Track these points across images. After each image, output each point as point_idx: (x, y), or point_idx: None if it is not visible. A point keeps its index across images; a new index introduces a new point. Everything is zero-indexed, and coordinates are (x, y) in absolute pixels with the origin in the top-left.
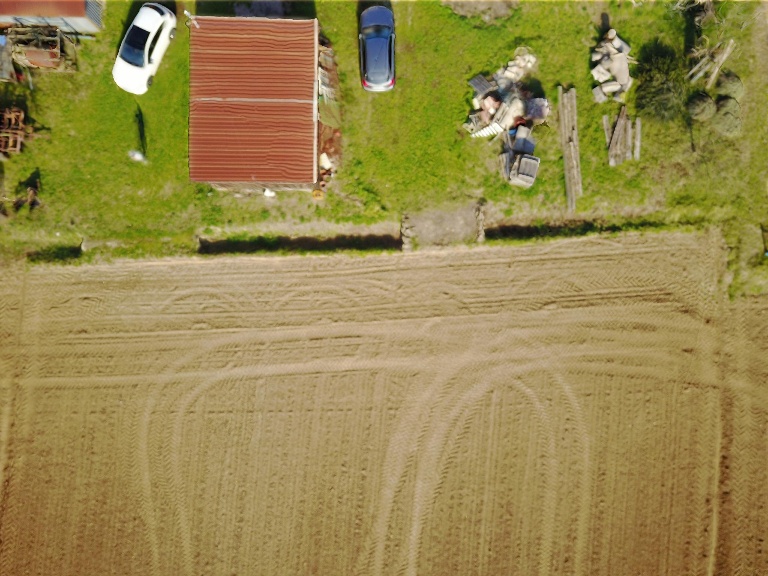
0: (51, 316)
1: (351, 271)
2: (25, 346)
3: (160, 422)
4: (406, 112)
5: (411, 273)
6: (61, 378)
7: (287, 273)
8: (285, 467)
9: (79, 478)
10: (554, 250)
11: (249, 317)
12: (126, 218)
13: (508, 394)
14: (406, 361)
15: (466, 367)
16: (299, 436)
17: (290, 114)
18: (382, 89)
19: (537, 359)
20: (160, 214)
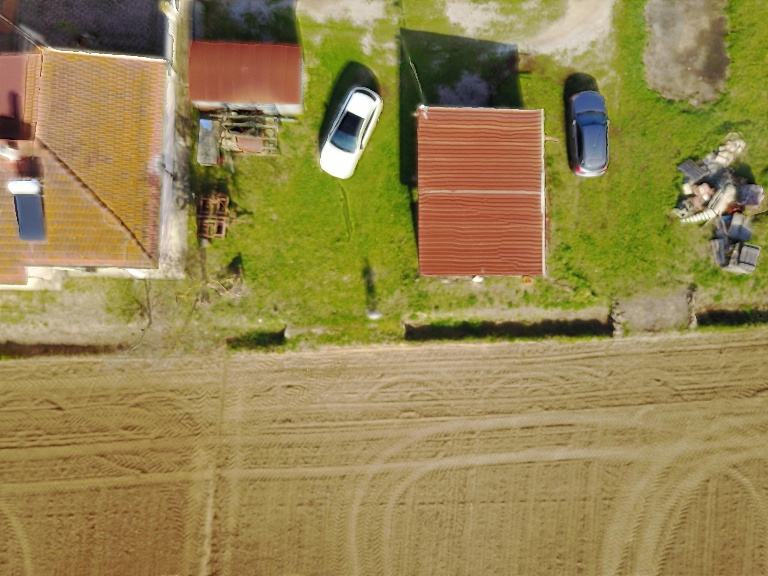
0: (253, 405)
1: (560, 357)
2: (227, 436)
3: (368, 514)
4: (615, 196)
5: (621, 359)
6: (266, 469)
7: (495, 360)
8: (498, 560)
9: (286, 573)
10: (765, 335)
11: (457, 405)
12: (331, 304)
13: (724, 483)
14: (619, 450)
15: (680, 455)
16: (512, 528)
17: (519, 206)
18: (594, 174)
19: (752, 447)
20: (366, 300)
